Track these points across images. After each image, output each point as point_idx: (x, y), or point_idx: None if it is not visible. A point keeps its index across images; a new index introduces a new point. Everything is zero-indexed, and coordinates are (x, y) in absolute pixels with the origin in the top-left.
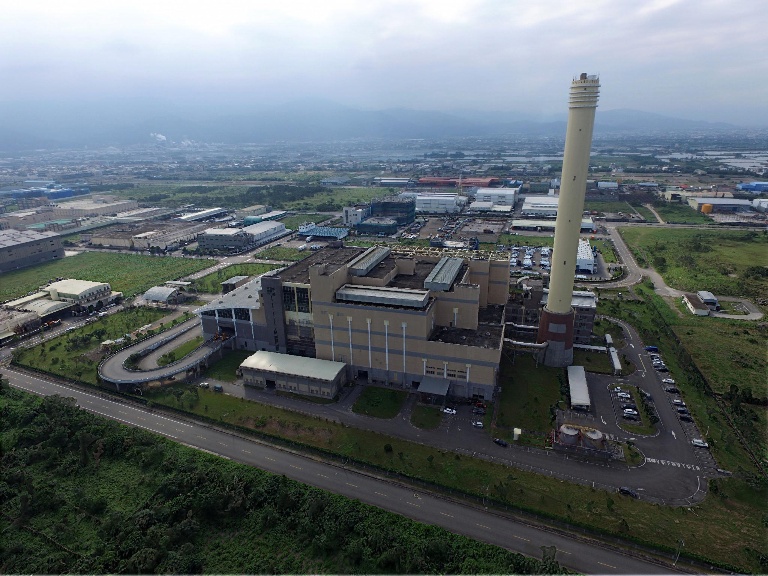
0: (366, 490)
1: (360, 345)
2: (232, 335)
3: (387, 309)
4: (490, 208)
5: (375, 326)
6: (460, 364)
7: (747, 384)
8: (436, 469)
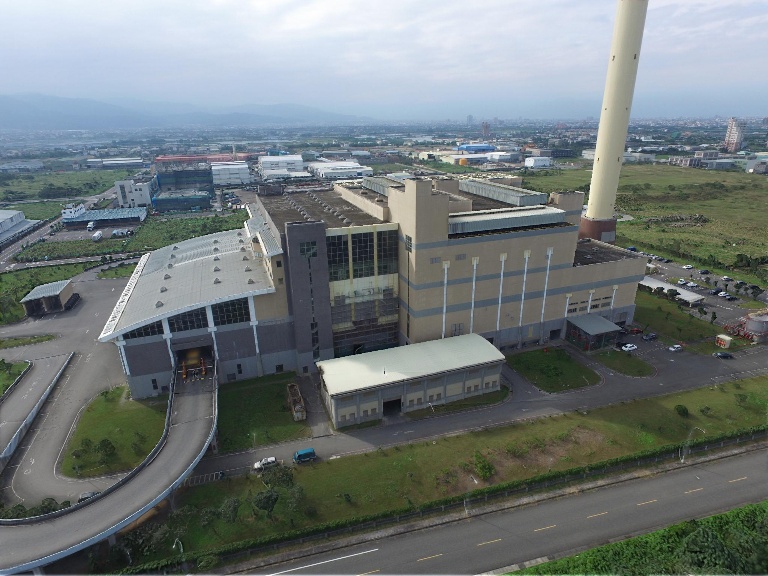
0: (762, 475)
1: (486, 300)
2: (207, 361)
3: (531, 232)
4: (289, 174)
5: (511, 263)
6: (607, 288)
7: (722, 256)
8: (753, 408)
